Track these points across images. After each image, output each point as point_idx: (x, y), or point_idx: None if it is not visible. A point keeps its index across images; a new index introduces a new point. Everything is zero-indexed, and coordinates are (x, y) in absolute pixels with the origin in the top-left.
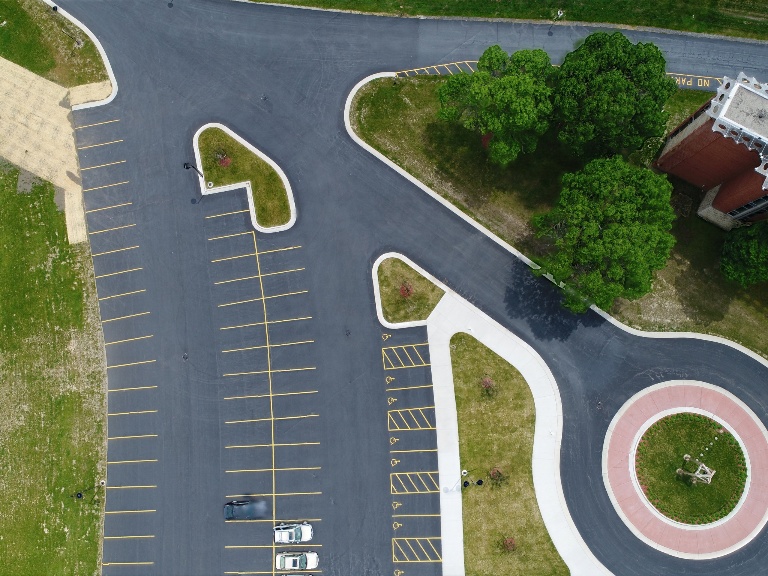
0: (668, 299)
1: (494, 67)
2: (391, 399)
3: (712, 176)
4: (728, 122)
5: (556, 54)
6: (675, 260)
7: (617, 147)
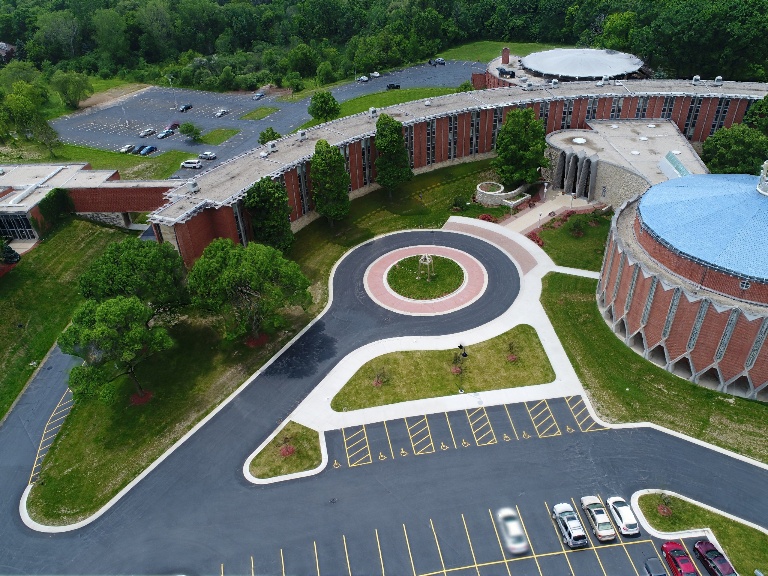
0: None
1: (80, 331)
2: (402, 453)
3: None
4: (180, 218)
5: (72, 363)
6: None
7: (180, 275)
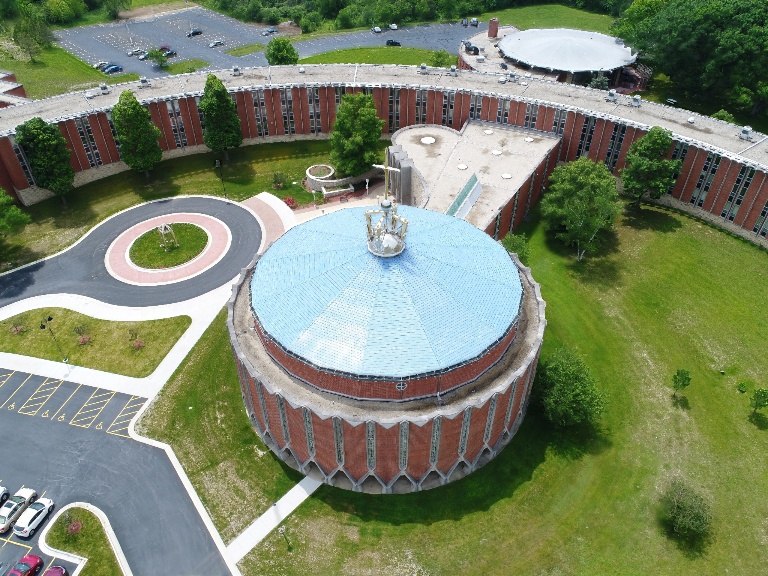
0: (64, 232)
1: None
2: None
3: (1, 184)
4: None
5: None
6: (44, 223)
7: None
